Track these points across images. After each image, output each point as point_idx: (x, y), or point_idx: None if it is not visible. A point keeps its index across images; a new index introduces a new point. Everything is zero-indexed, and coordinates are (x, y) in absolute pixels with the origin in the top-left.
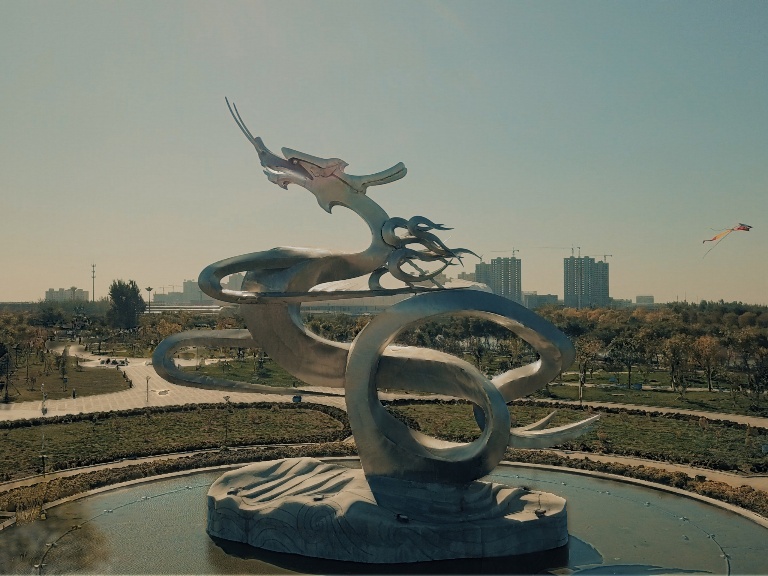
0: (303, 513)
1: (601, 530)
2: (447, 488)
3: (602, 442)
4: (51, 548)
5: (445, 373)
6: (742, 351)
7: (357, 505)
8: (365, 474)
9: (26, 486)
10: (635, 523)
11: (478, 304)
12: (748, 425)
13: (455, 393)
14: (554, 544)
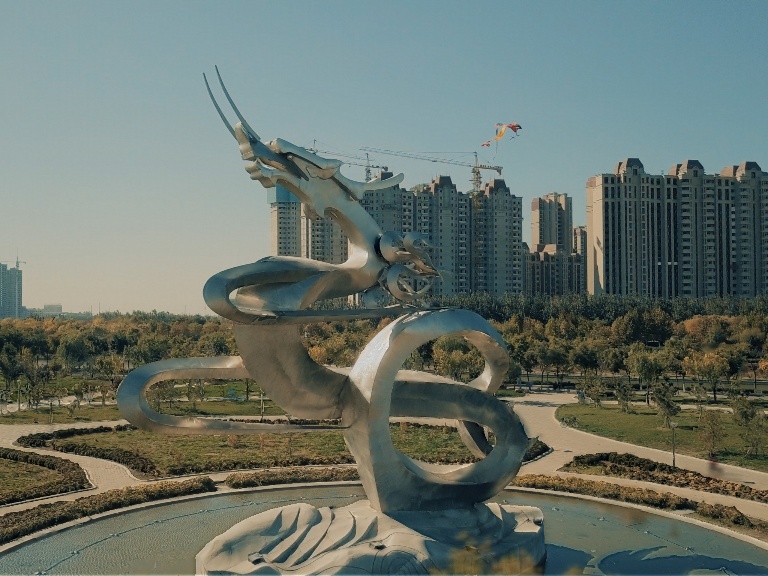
0: (378, 566)
1: None
2: (465, 512)
3: None
4: None
5: (446, 395)
6: (335, 360)
7: (430, 545)
8: (382, 512)
9: None
10: None
11: (472, 324)
12: (445, 424)
13: (448, 415)
14: None
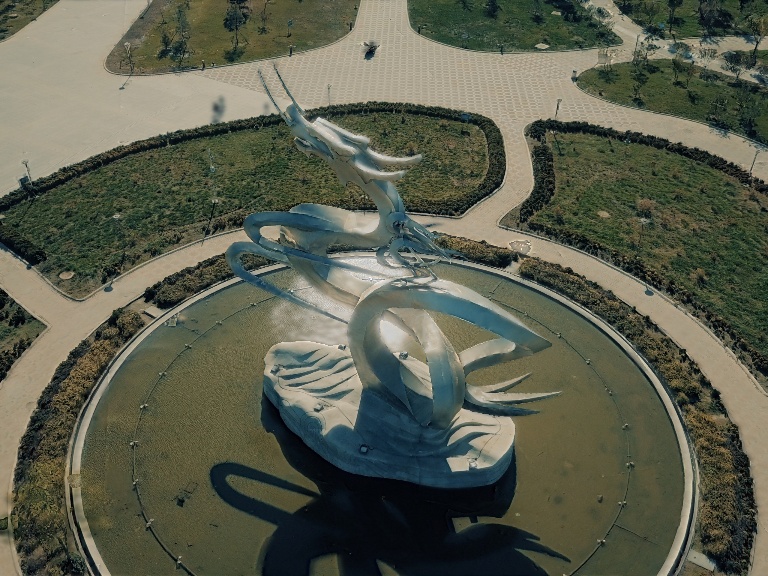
0: (304, 419)
1: (547, 461)
2: (412, 424)
3: (697, 279)
4: (161, 378)
5: None
6: None
7: (336, 429)
8: (363, 388)
9: (177, 274)
10: (586, 456)
11: (452, 309)
12: None
13: None
14: (482, 484)
